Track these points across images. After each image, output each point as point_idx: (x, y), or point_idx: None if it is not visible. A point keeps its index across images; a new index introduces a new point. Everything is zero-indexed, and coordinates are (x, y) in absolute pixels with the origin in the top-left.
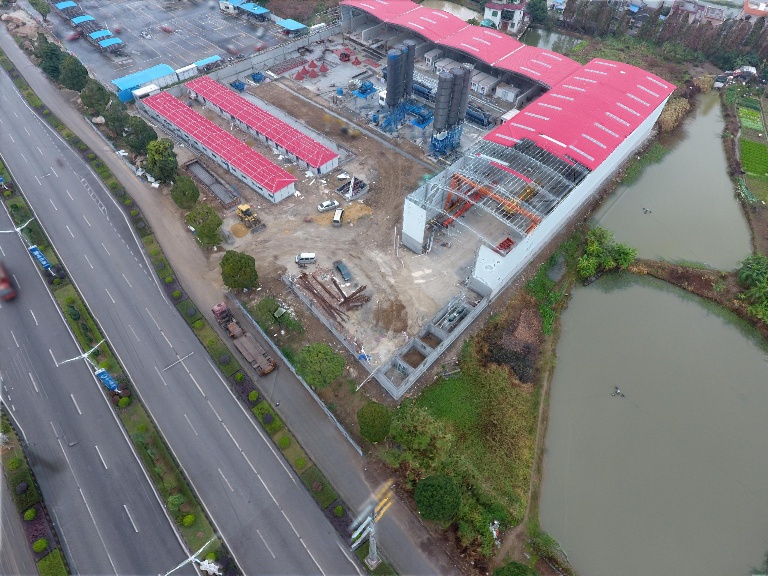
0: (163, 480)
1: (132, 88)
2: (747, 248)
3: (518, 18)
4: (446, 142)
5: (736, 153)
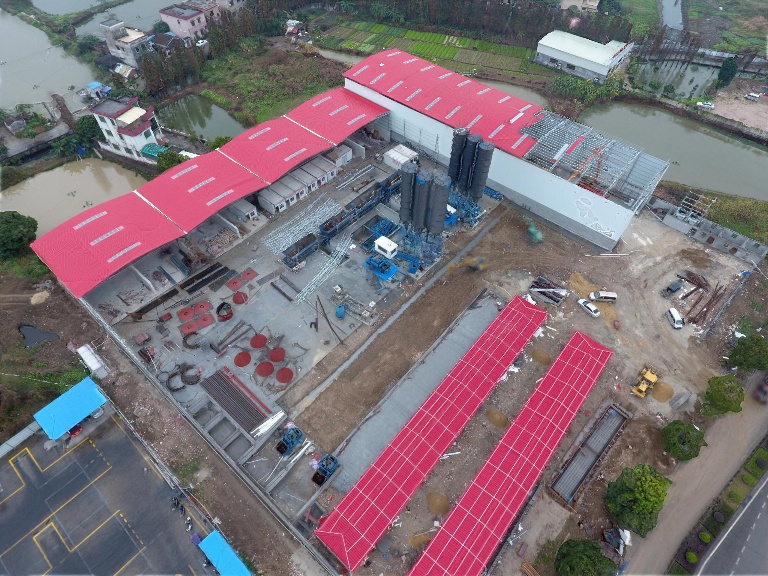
0: None
1: None
2: (519, 89)
3: None
4: None
5: None
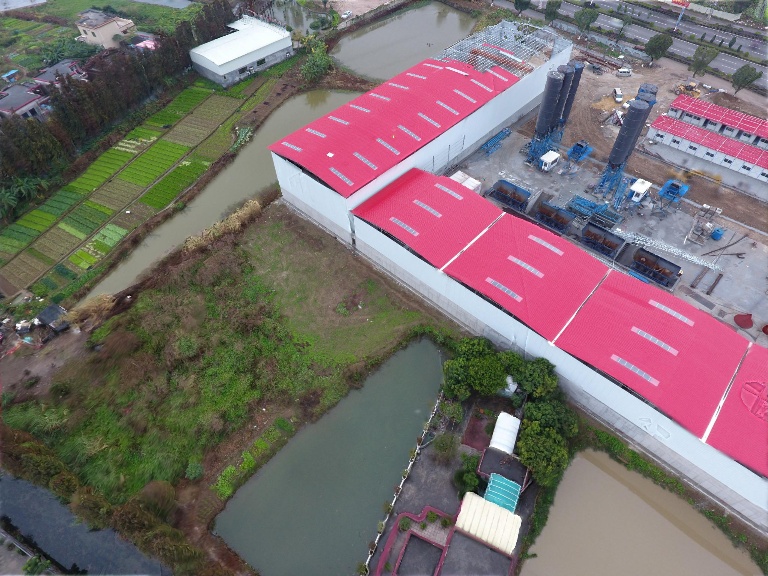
0: None
1: None
2: None
3: None
4: None
5: None
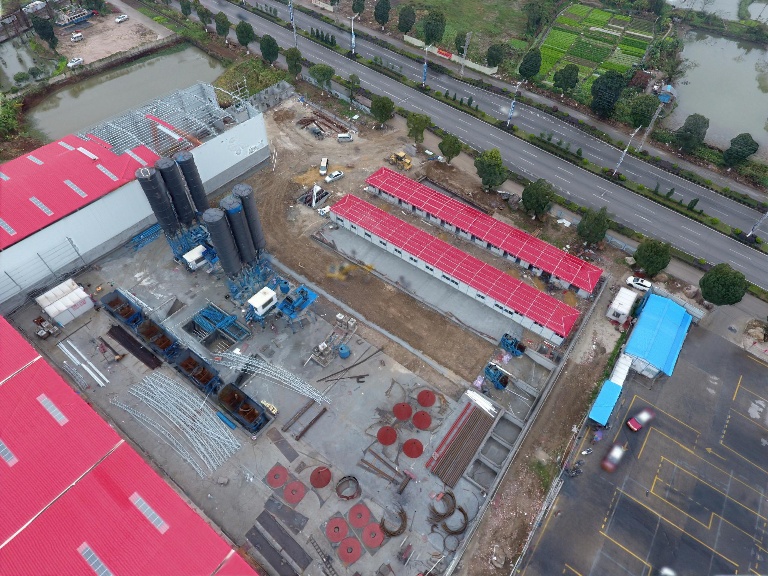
0: (387, 70)
1: (644, 300)
2: None
3: None
4: None
5: None
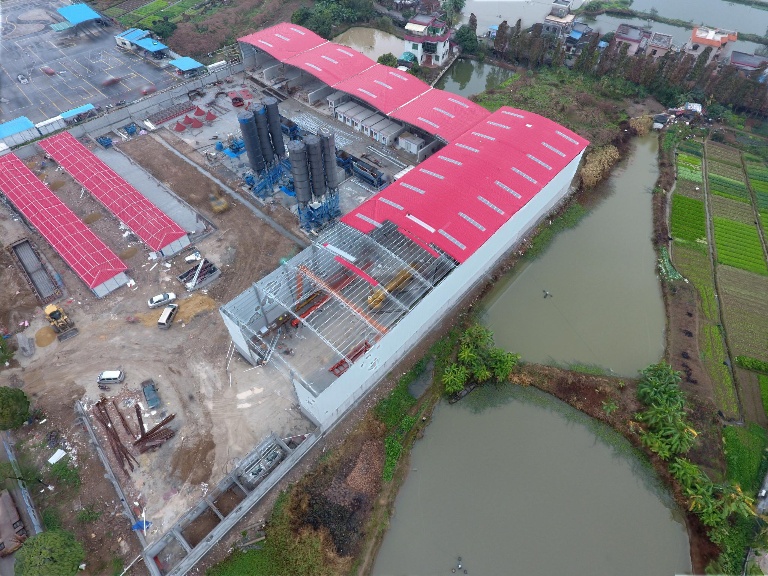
0: None
1: None
2: (660, 343)
3: (442, 50)
4: (322, 211)
5: (666, 213)
